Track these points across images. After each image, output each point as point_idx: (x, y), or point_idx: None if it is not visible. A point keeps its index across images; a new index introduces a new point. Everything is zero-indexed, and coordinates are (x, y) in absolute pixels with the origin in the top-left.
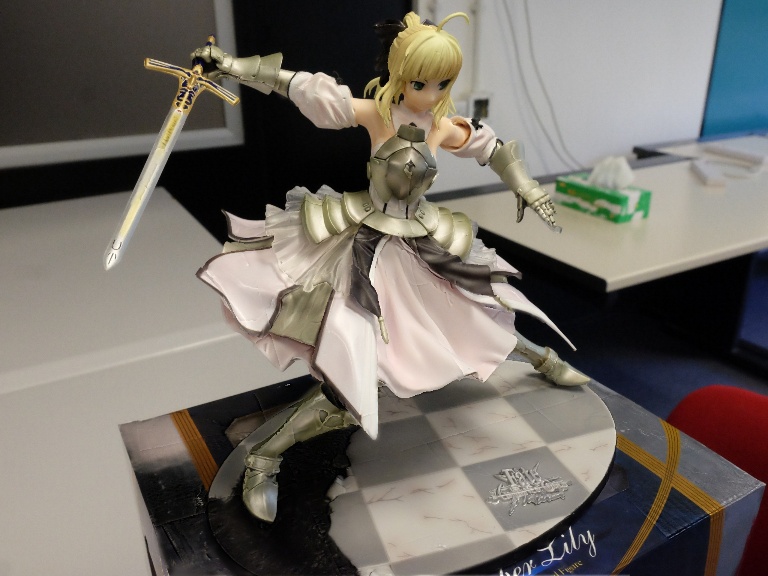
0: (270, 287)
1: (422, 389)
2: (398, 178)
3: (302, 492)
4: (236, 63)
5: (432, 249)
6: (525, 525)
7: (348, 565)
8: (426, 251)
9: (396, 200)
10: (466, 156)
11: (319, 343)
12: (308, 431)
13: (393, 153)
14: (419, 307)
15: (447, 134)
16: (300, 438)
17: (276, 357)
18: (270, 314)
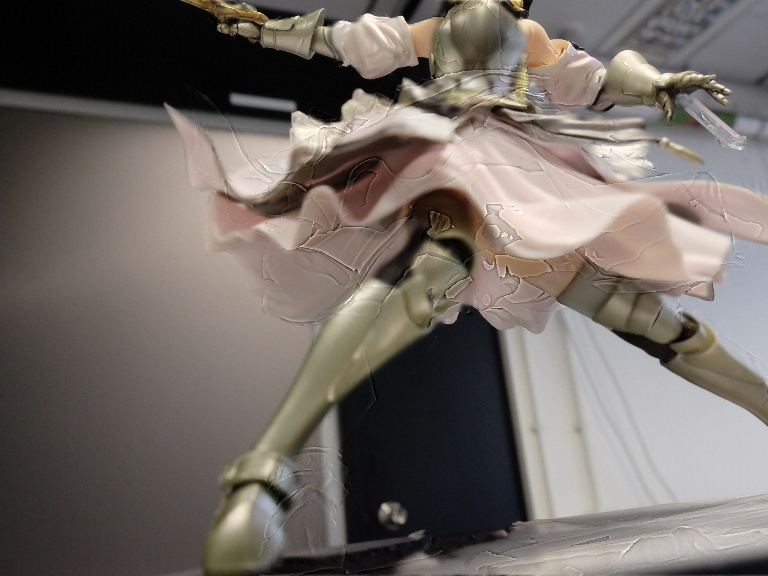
0: (306, 136)
1: (620, 216)
2: (481, 30)
3: None
4: (260, 16)
5: (557, 104)
6: None
7: (584, 567)
8: (549, 105)
9: (485, 66)
10: (566, 94)
11: (397, 97)
12: (400, 352)
13: (467, 2)
14: (564, 174)
15: (533, 28)
16: (385, 378)
17: (321, 213)
18: (307, 158)
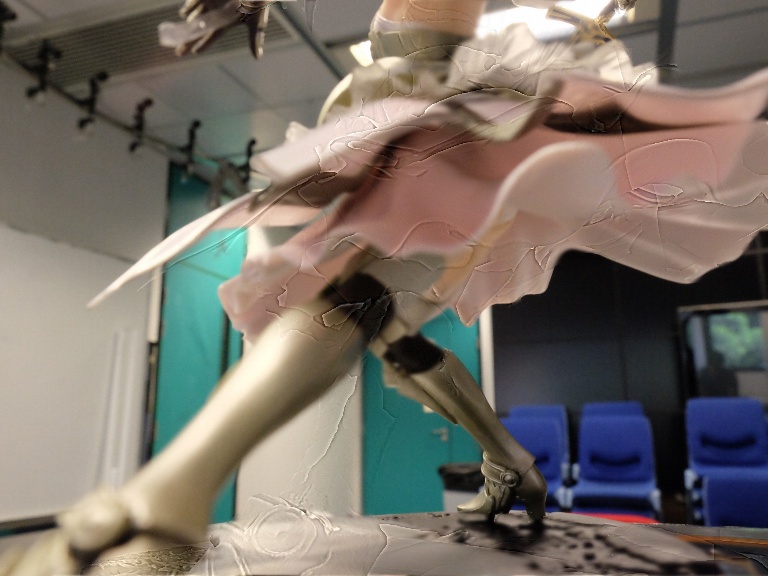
0: None
1: None
2: None
3: (489, 536)
4: None
5: None
6: (158, 550)
7: None
8: None
9: None
10: None
11: None
12: None
13: None
14: None
15: None
16: None
17: None
18: None
